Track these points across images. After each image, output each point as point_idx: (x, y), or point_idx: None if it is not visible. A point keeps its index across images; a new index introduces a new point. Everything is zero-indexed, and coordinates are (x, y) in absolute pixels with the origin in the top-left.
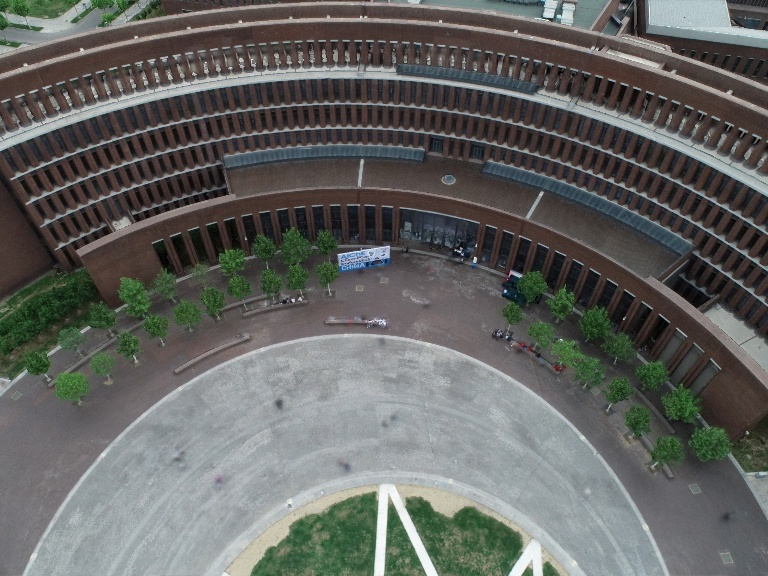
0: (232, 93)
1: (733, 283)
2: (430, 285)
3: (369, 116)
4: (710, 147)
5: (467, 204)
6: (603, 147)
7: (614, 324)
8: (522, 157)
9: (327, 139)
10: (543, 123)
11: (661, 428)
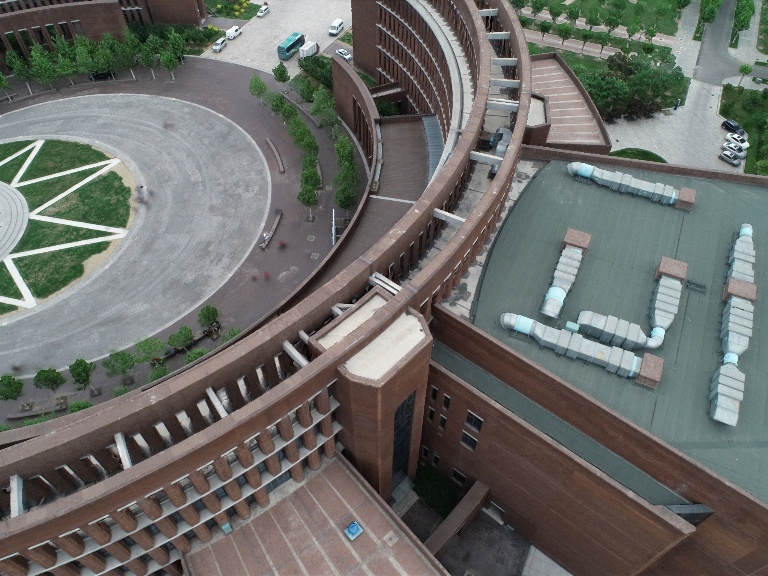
0: None
1: None
2: None
3: None
4: None
5: None
6: None
7: None
8: None
9: None
10: None
11: None
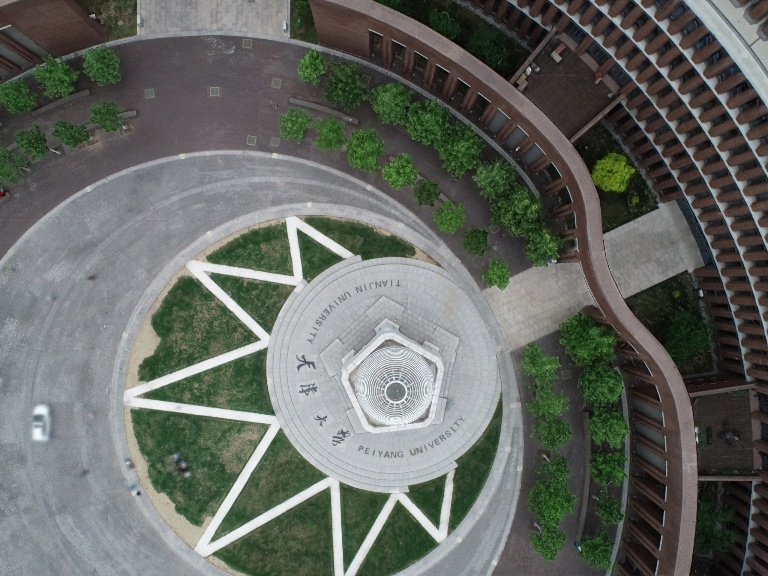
0: None
1: None
2: None
3: None
4: None
5: None
6: None
7: None
8: None
9: None
10: None
11: (83, 102)
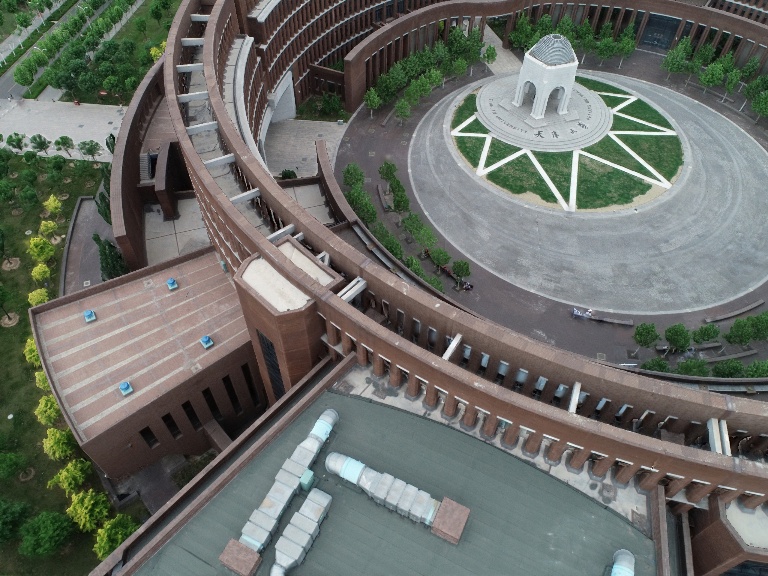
0: None
1: None
2: None
3: None
4: None
5: None
6: None
7: None
8: None
9: None
10: None
11: None
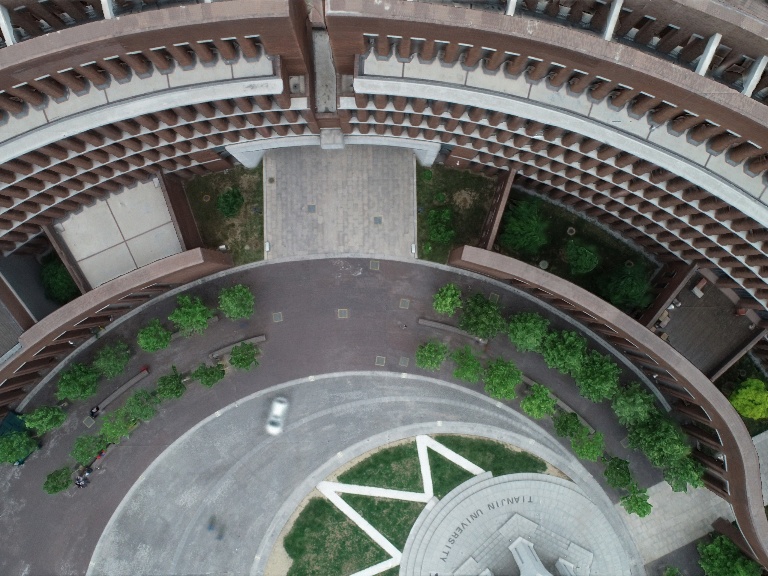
0: None
1: (30, 220)
2: (0, 553)
3: None
4: None
5: None
6: None
7: None
8: None
9: None
10: None
11: (211, 328)
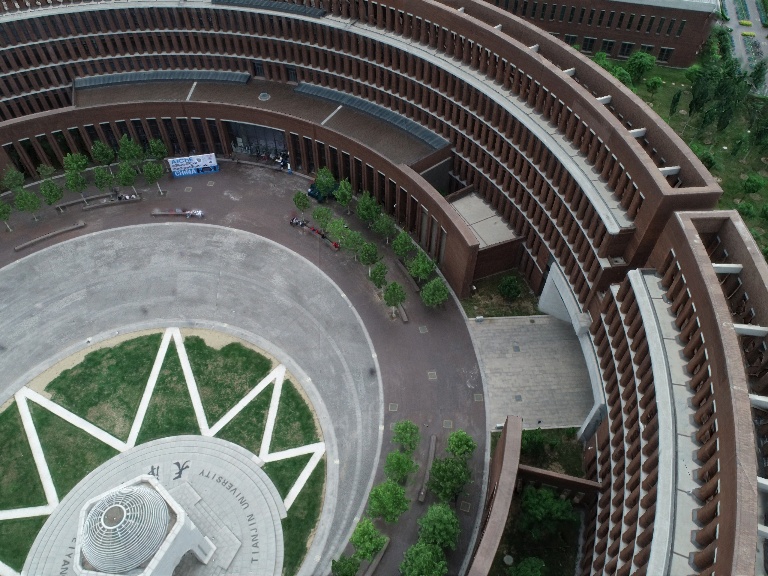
0: (71, 19)
1: (477, 172)
2: (249, 187)
3: (197, 43)
4: (448, 55)
5: (271, 113)
6: (377, 61)
7: (395, 215)
8: (325, 77)
9: (166, 65)
10: (333, 44)
11: (410, 288)
